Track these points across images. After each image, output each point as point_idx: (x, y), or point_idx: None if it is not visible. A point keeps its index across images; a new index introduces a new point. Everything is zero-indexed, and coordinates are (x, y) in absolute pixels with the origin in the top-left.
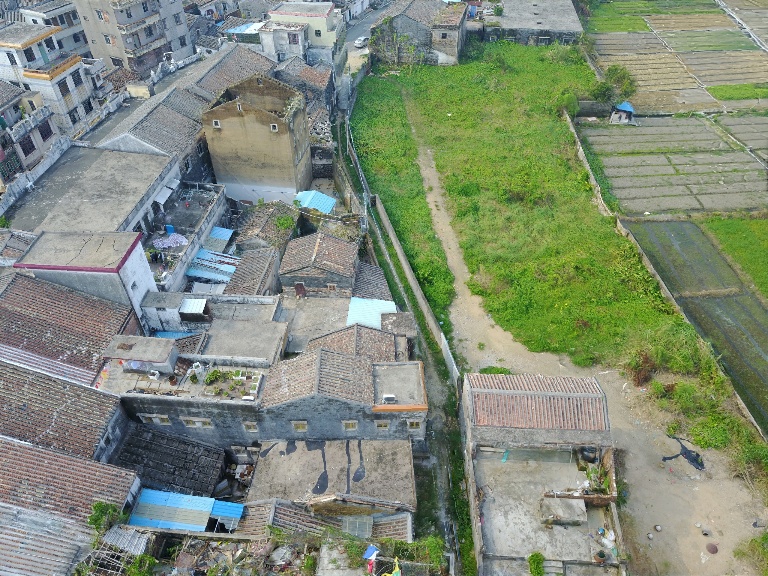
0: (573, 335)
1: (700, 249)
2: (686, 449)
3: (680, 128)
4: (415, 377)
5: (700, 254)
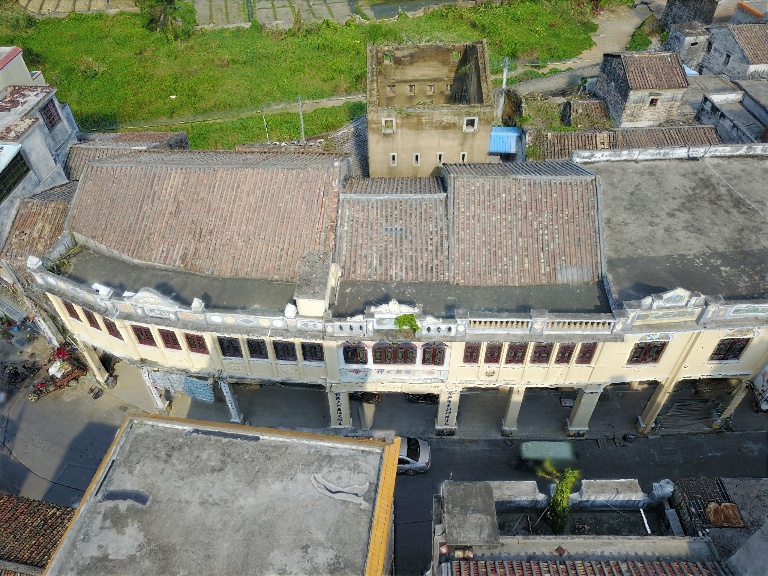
0: (569, 29)
1: (409, 5)
2: (642, 3)
3: (200, 1)
4: (756, 4)
5: (416, 6)
